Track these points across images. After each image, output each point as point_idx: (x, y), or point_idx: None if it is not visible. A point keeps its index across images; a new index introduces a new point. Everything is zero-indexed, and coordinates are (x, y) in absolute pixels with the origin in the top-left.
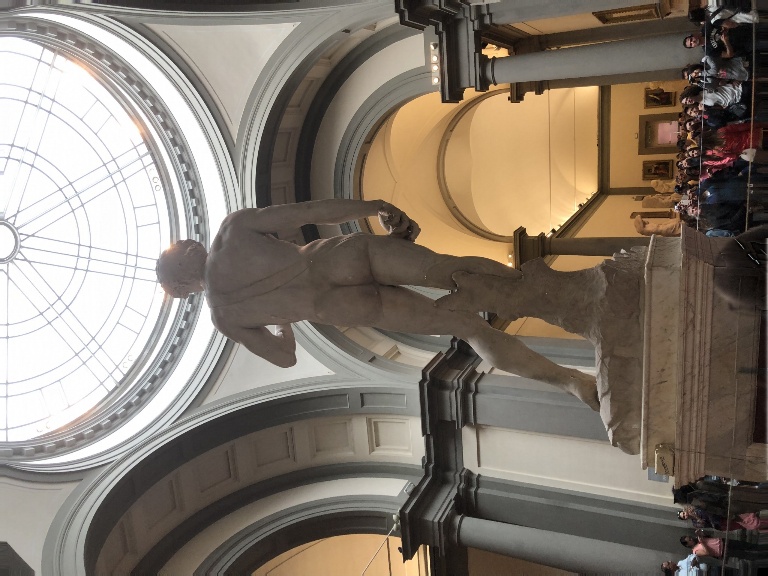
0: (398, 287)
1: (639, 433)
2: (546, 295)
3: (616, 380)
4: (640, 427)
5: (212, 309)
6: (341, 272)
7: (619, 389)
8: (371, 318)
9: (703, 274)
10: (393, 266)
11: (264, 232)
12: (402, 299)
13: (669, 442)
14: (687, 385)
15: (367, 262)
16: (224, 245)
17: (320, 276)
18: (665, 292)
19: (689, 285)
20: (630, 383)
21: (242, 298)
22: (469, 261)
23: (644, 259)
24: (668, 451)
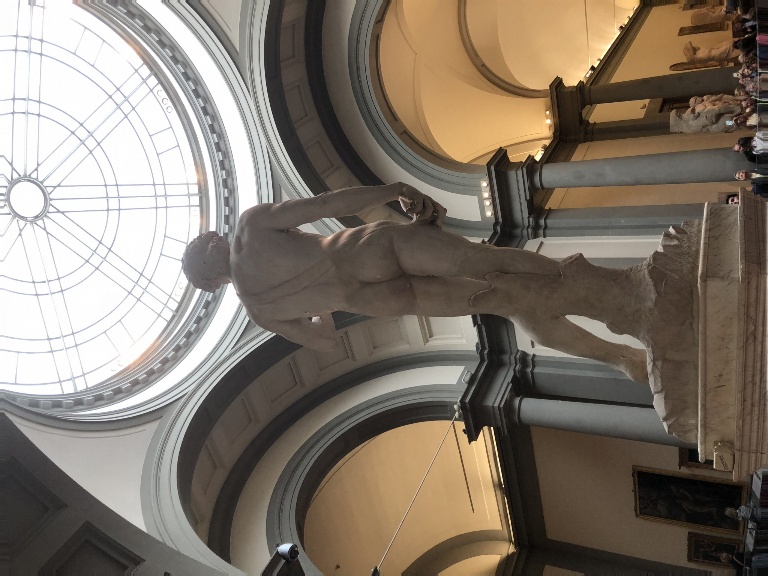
0: None
1: (696, 427)
2: (589, 298)
3: (670, 381)
4: (697, 423)
5: (245, 306)
6: (368, 272)
7: (673, 389)
8: (406, 311)
9: (765, 287)
10: (422, 261)
11: (282, 229)
12: (436, 288)
13: (728, 439)
14: (747, 392)
15: (394, 258)
16: (244, 247)
17: (347, 274)
18: (722, 302)
19: (749, 299)
20: (685, 384)
21: (273, 298)
22: (502, 256)
23: (697, 249)
24: (727, 450)
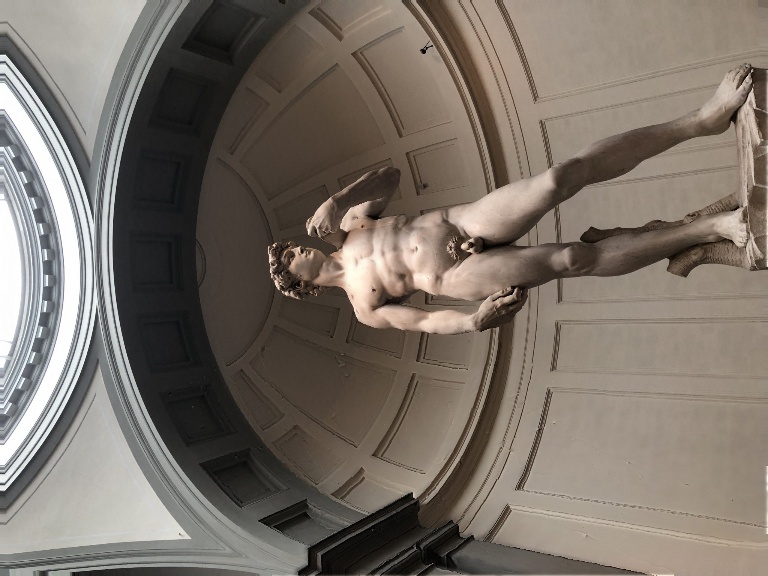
0: (510, 243)
1: None
2: None
3: None
4: None
5: None
6: None
7: None
8: None
9: None
10: None
11: None
12: None
13: None
14: None
15: None
16: None
17: None
18: None
19: None
20: None
21: None
22: None
23: None
24: None
